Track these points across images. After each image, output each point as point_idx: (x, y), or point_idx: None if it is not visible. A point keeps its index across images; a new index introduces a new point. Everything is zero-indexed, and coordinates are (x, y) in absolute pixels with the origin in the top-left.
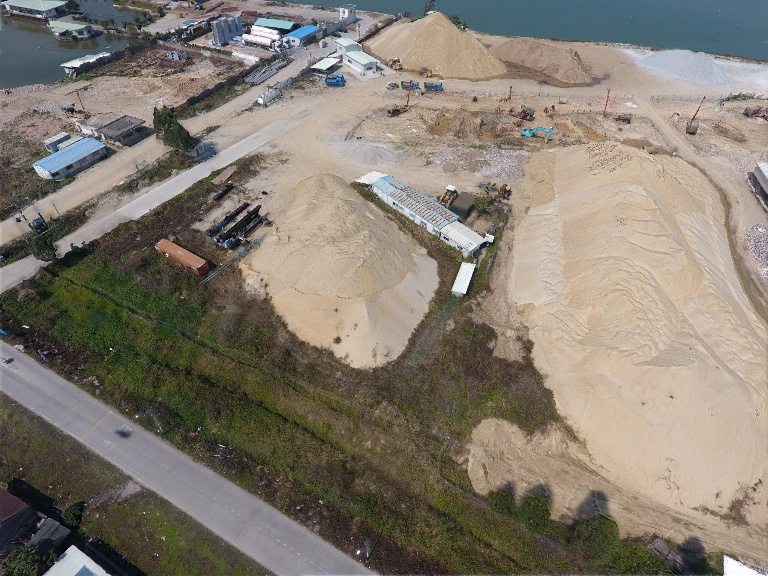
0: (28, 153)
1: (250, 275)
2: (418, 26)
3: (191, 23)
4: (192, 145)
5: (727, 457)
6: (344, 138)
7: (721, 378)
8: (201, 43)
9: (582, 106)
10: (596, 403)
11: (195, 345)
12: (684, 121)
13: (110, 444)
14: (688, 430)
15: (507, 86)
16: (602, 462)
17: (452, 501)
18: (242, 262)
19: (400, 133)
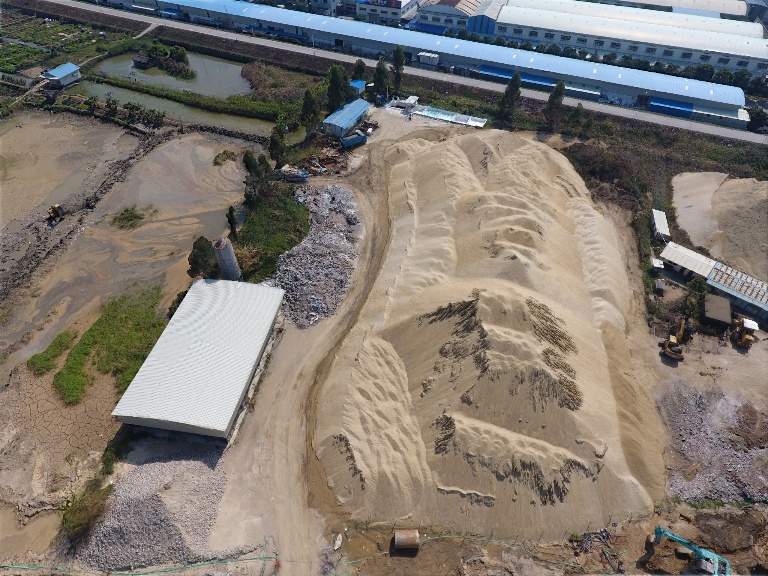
0: None
1: None
2: None
3: None
4: None
5: None
6: None
7: (483, 136)
8: None
9: None
10: None
11: None
12: None
13: None
14: None
15: None
16: None
17: None
18: None
19: None
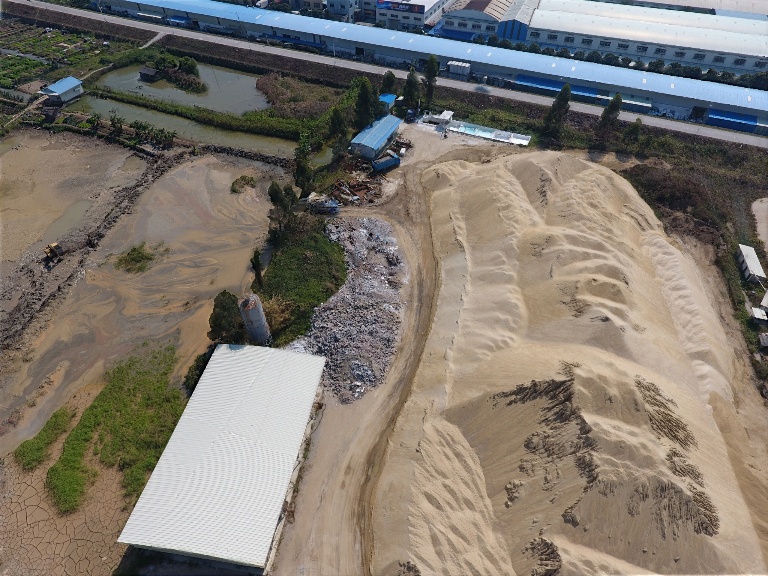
0: None
1: None
2: None
3: None
4: None
5: None
6: None
7: (537, 159)
8: None
9: None
10: None
11: None
12: None
13: None
14: None
15: None
16: None
17: None
18: None
19: None
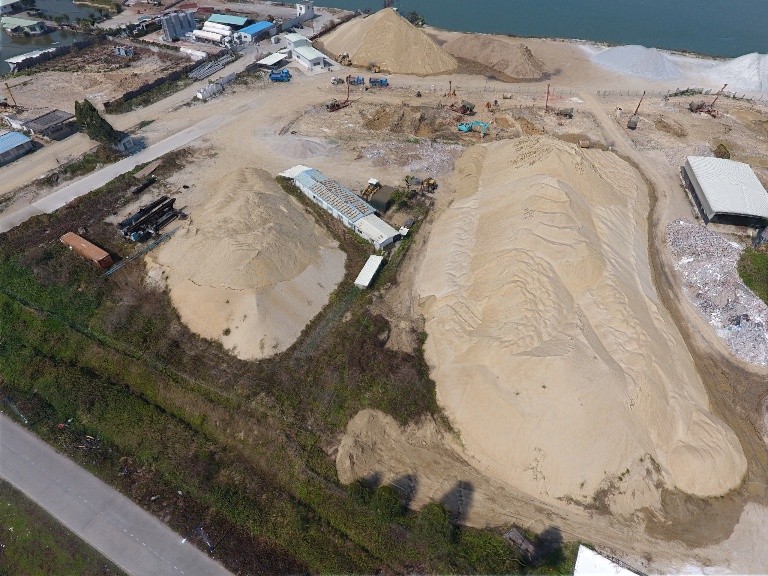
0: None
1: (153, 268)
2: (368, 22)
3: (144, 19)
4: (117, 139)
5: (594, 447)
6: (278, 132)
7: (596, 368)
8: (152, 39)
9: (526, 101)
10: (472, 393)
11: (82, 337)
12: (627, 116)
13: None
14: (557, 420)
15: (454, 81)
16: (474, 452)
17: (314, 491)
18: (148, 255)
19: (336, 128)
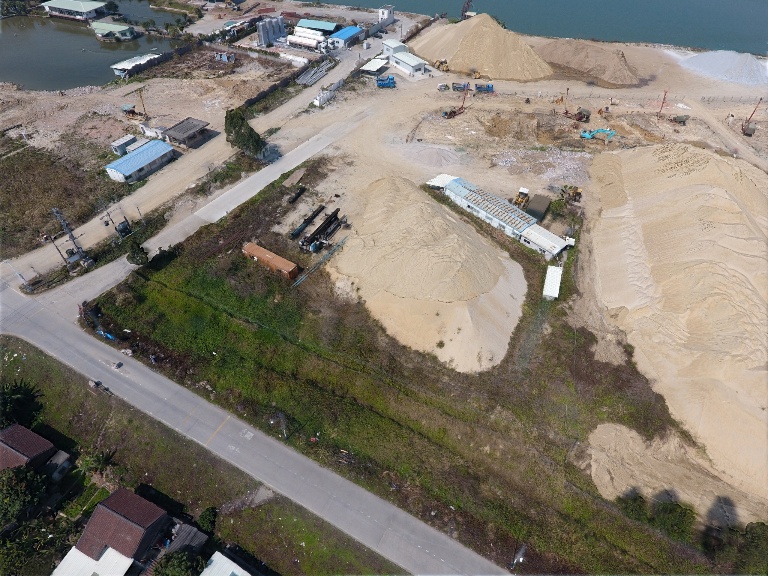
0: (95, 155)
1: (340, 278)
2: (464, 27)
3: (234, 24)
4: (261, 147)
5: None
6: (405, 140)
7: None
8: (246, 44)
9: (634, 107)
10: (713, 408)
11: (299, 349)
12: (739, 122)
13: (235, 449)
14: None
15: (556, 87)
16: (724, 467)
17: (581, 507)
18: (329, 265)
19: (460, 135)
